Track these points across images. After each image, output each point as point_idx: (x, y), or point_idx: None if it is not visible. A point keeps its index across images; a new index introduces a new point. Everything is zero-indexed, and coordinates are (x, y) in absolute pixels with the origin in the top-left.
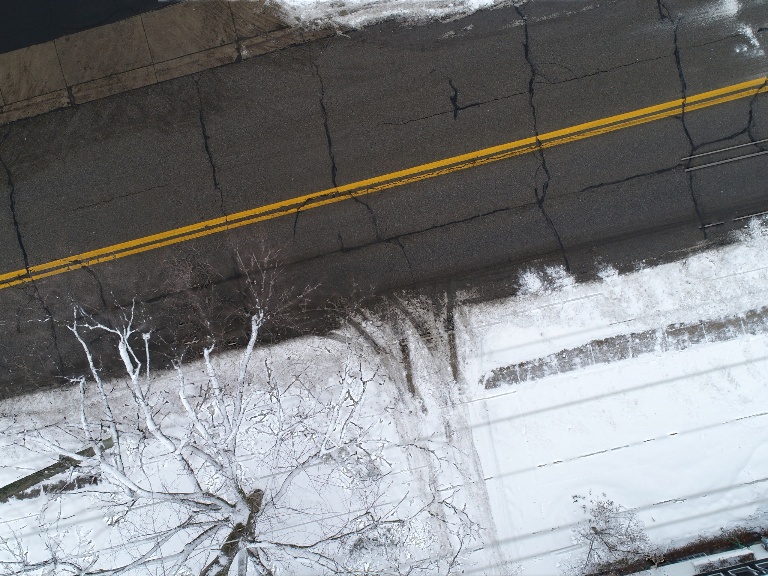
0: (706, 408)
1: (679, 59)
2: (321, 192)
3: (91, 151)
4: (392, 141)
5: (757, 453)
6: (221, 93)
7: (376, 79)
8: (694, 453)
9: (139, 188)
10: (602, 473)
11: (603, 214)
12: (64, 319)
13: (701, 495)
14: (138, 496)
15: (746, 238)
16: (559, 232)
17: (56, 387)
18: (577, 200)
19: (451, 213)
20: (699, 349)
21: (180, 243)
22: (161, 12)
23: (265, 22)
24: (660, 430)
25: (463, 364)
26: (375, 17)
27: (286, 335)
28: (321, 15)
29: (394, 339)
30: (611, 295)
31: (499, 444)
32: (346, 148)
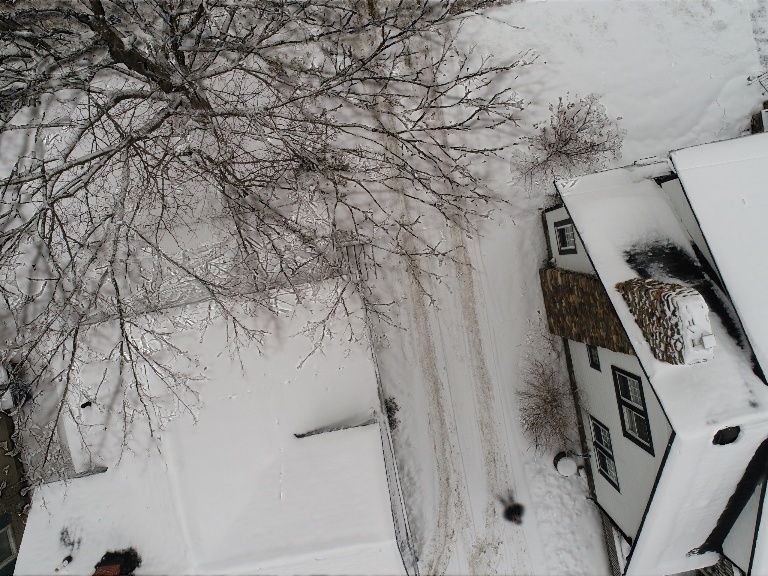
0: (678, 35)
1: None
2: None
3: None
4: None
5: (729, 85)
6: None
7: None
8: (663, 83)
9: None
10: (566, 100)
11: None
12: None
13: (668, 127)
14: None
15: None
16: None
17: None
18: None
19: None
20: None
21: None
22: None
23: None
24: (629, 57)
25: None
26: None
27: None
28: None
29: None
30: None
31: None
32: None
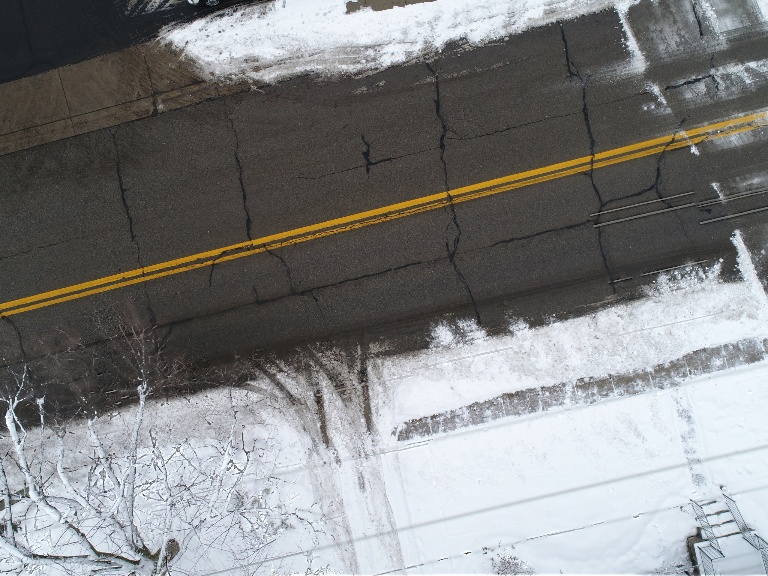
0: (614, 462)
1: (588, 116)
2: (236, 245)
3: (10, 202)
4: (306, 195)
5: (664, 507)
6: (138, 146)
7: (290, 134)
8: (602, 506)
9: (57, 239)
10: (511, 525)
11: (513, 269)
12: None
13: (609, 548)
14: None
15: (654, 293)
16: (470, 286)
17: None
18: (488, 255)
19: (364, 267)
20: (607, 403)
21: (98, 294)
22: (78, 66)
23: (181, 77)
24: (568, 483)
25: (376, 416)
26: (288, 73)
27: (202, 386)
28: (235, 70)
29: (309, 390)
30: (520, 349)
31: (410, 496)
32: (260, 202)
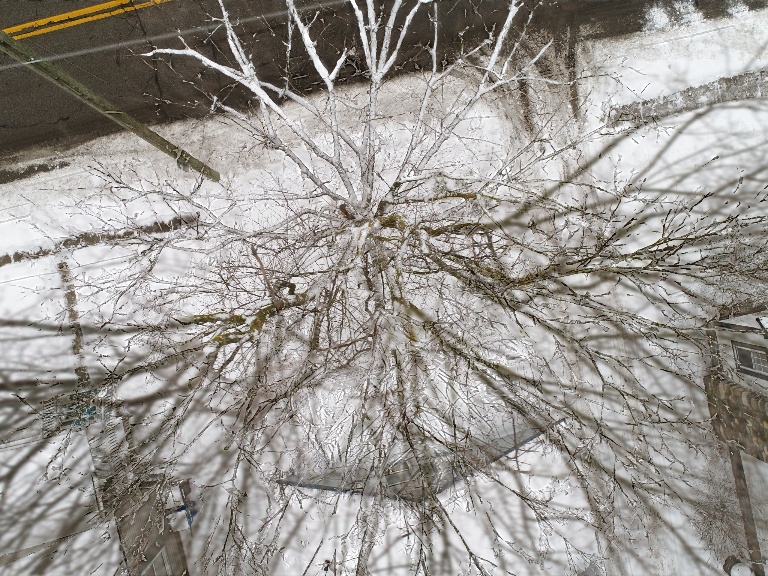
0: None
1: None
2: None
3: None
4: None
5: None
6: None
7: None
8: None
9: None
10: (728, 212)
11: None
12: None
13: None
14: (279, 143)
15: None
16: None
17: (155, 124)
18: None
19: None
20: None
21: None
22: None
23: None
24: None
25: None
26: None
27: (399, 70)
28: None
29: None
30: (743, 28)
31: None
32: None
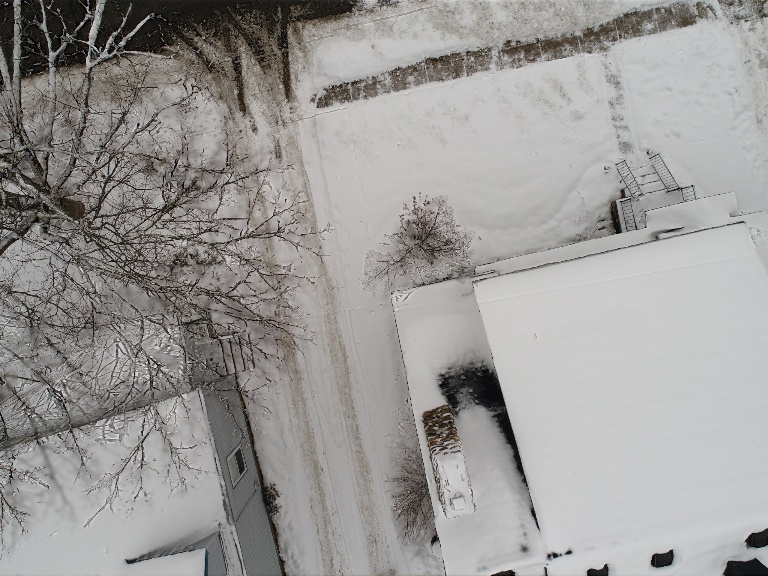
0: (538, 125)
1: None
2: None
3: None
4: None
5: (588, 172)
6: None
7: None
8: (524, 172)
9: None
10: (430, 191)
11: None
12: None
13: (530, 215)
14: None
15: None
16: None
17: None
18: None
19: None
20: (533, 65)
21: None
22: None
23: None
24: (490, 147)
25: (295, 82)
26: None
27: None
28: None
29: (227, 56)
30: (445, 8)
31: (327, 161)
32: None
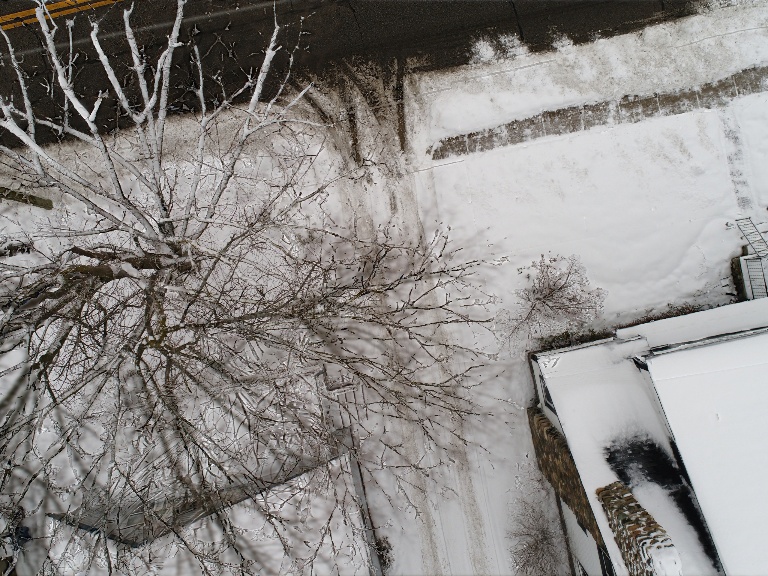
0: (657, 180)
1: None
2: None
3: None
4: None
5: (708, 228)
6: None
7: None
8: (643, 226)
9: None
10: (549, 245)
11: None
12: (3, 79)
13: (649, 270)
14: None
15: (704, 10)
16: None
17: None
18: None
19: None
20: (652, 120)
21: (125, 1)
22: None
23: None
24: (609, 202)
25: (411, 134)
26: None
27: None
28: None
29: (341, 107)
30: (564, 62)
31: (444, 213)
32: None
